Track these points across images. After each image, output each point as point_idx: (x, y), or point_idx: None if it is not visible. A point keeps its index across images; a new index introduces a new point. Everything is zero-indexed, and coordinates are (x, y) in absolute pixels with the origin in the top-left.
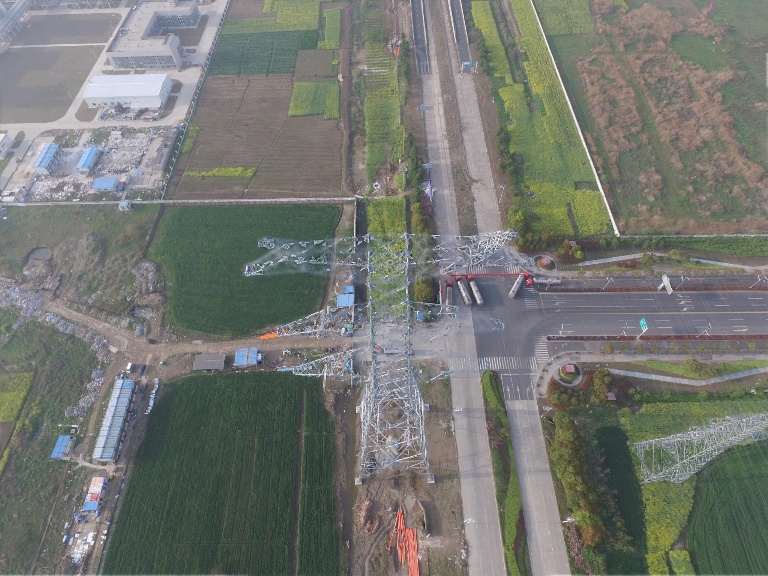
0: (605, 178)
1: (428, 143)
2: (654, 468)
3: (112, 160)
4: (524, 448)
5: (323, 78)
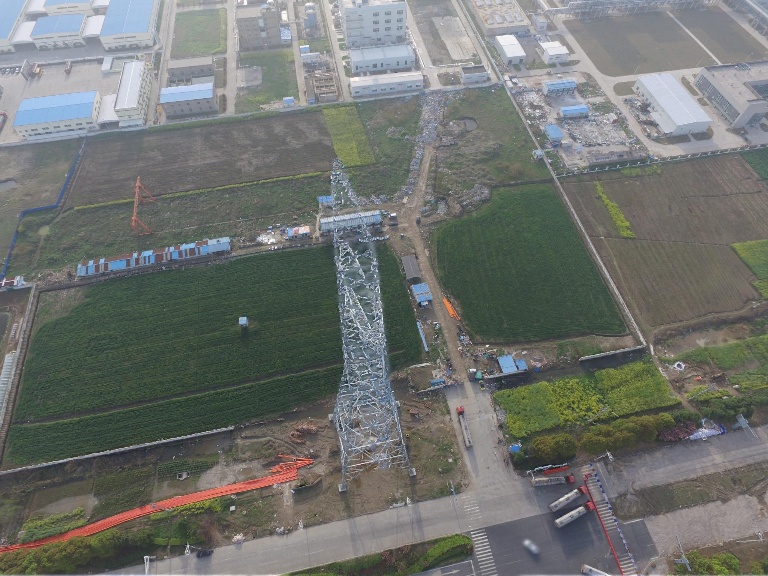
0: None
1: None
2: None
3: (582, 126)
4: None
5: None
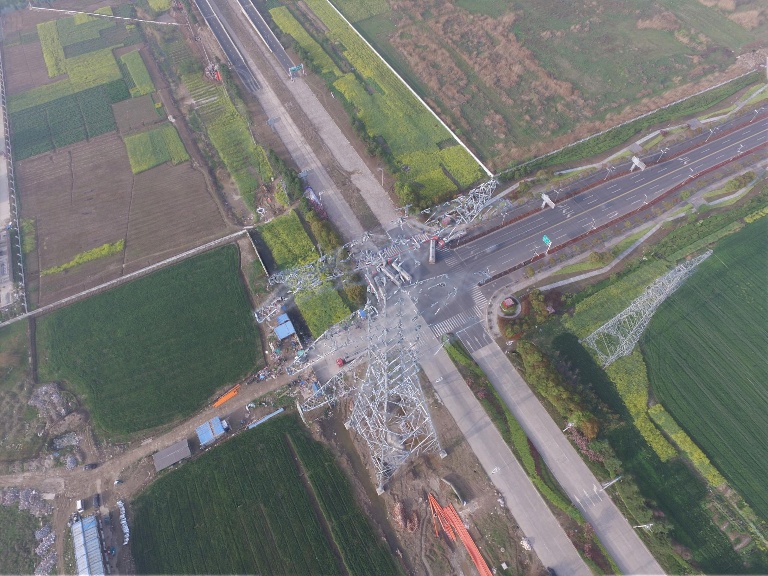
0: (460, 132)
1: (291, 153)
2: (609, 351)
3: None
4: (505, 386)
5: (153, 125)
